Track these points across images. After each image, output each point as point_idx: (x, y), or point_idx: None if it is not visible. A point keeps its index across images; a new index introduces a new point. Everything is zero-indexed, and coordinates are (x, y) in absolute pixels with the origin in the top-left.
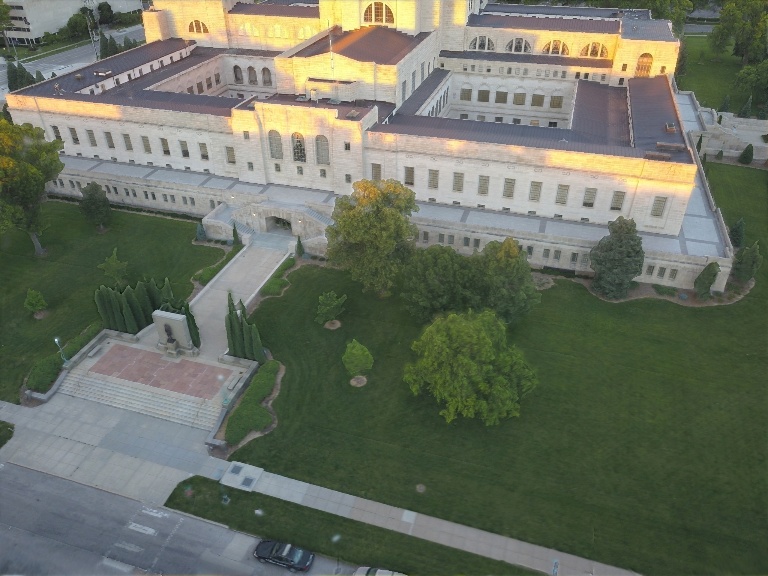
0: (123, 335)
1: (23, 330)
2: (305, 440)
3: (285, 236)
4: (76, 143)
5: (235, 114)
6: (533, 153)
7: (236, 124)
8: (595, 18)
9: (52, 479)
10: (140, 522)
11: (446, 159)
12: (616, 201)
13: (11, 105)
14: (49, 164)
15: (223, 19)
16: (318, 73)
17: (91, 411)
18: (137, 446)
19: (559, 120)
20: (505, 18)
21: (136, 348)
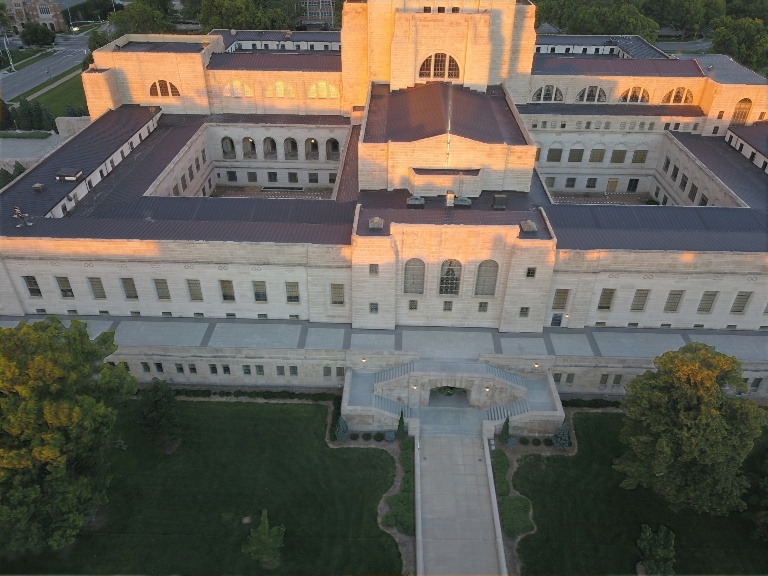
0: None
1: None
2: None
3: (458, 408)
4: (66, 296)
5: (360, 243)
6: None
7: (359, 256)
8: (589, 47)
9: None
10: None
11: (665, 276)
12: None
13: None
14: (116, 387)
15: (202, 77)
16: (425, 161)
17: None
18: None
19: (641, 176)
20: (566, 62)
21: None
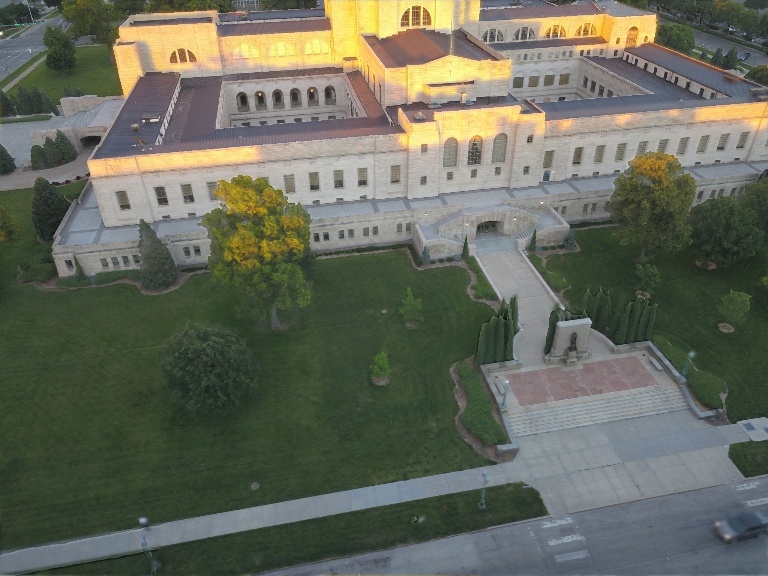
0: (507, 364)
1: (387, 400)
2: (759, 384)
3: (495, 238)
4: (187, 202)
5: (415, 128)
6: (686, 113)
7: (414, 139)
8: None
9: (631, 506)
10: (750, 498)
11: (614, 133)
12: (741, 141)
13: (95, 173)
14: (302, 216)
15: (216, 43)
16: (434, 78)
17: (570, 439)
18: (653, 446)
19: (567, 95)
20: (501, 11)
21: (532, 371)
